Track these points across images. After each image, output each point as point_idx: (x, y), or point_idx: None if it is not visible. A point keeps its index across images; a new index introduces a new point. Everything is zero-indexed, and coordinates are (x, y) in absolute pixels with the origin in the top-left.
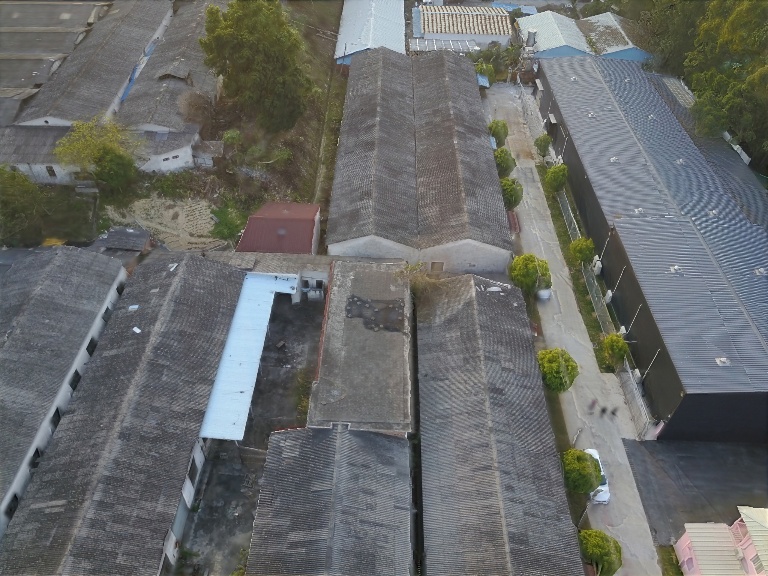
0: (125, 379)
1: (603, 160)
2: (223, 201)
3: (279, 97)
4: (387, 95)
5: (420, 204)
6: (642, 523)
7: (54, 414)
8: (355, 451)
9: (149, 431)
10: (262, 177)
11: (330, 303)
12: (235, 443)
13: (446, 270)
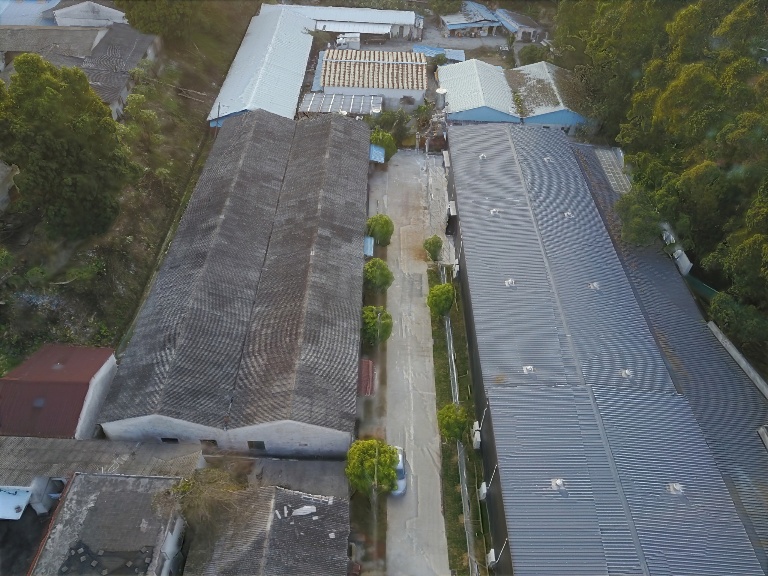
0: None
1: (496, 283)
2: None
3: (71, 202)
4: (246, 179)
5: (246, 351)
6: None
7: None
8: None
9: None
10: (52, 304)
11: (40, 559)
12: None
13: (270, 449)
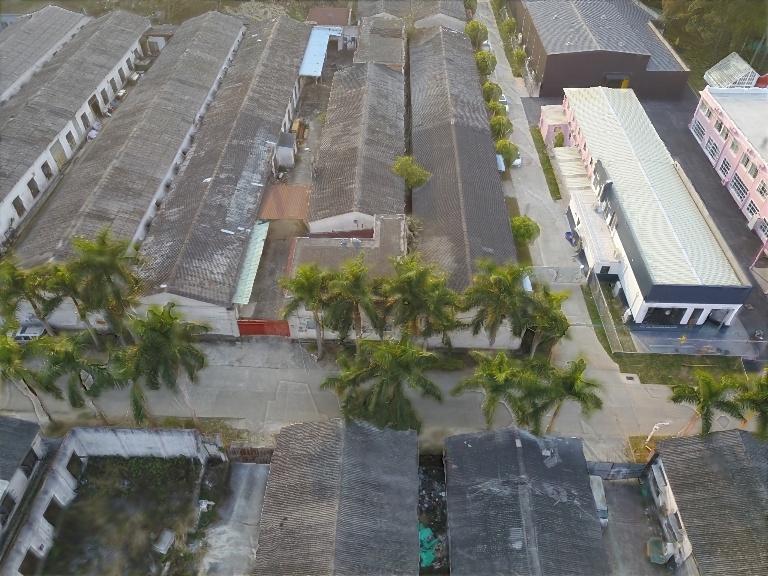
0: (259, 52)
1: None
2: (293, 7)
3: None
4: None
5: (412, 6)
6: (524, 120)
7: (224, 68)
8: (377, 70)
9: (275, 67)
10: None
11: (361, 30)
12: (316, 83)
13: None
